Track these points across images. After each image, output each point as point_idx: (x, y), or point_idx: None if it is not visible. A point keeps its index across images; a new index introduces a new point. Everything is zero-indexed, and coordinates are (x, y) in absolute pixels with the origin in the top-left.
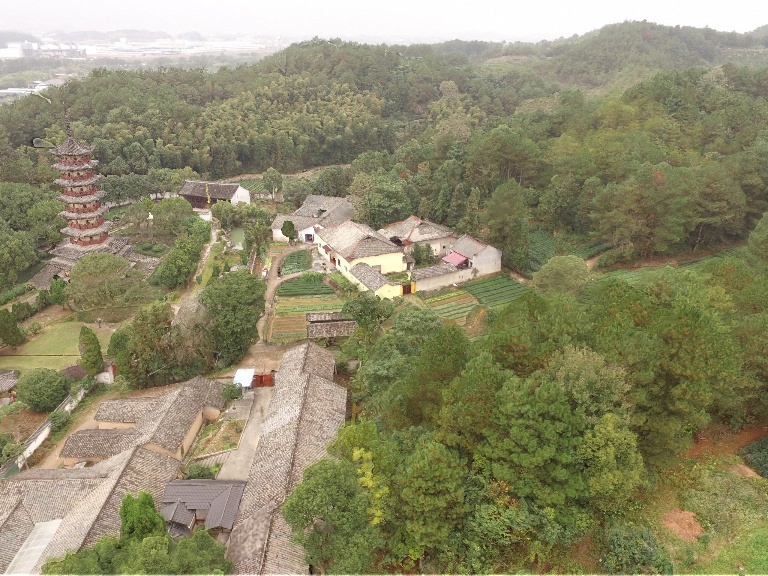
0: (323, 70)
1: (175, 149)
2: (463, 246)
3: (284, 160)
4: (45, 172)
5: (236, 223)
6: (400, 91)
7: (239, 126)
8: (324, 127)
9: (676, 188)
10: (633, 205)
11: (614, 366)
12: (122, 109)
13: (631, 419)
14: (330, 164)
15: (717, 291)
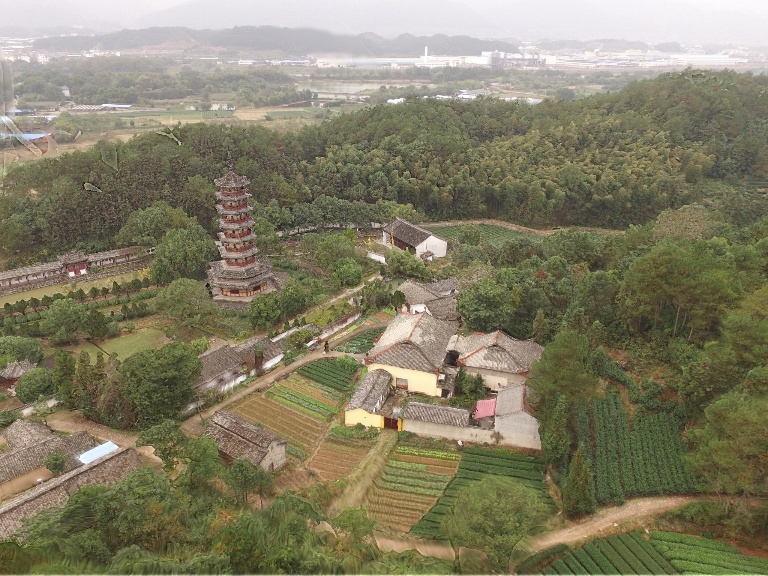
0: (653, 111)
1: (417, 183)
2: (508, 396)
3: (533, 212)
4: (284, 189)
5: (402, 274)
6: (747, 148)
7: (498, 168)
8: (596, 182)
9: None
10: (750, 448)
11: None
12: (392, 137)
13: None
14: (595, 226)
15: None
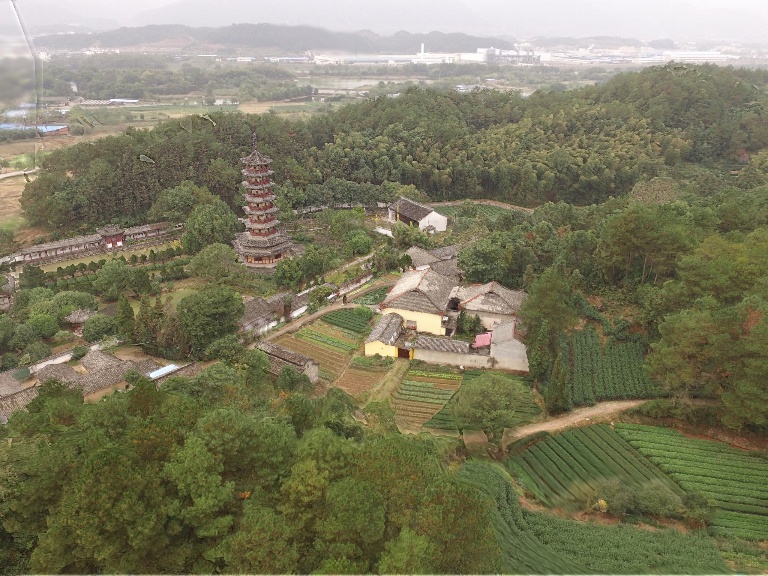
0: (637, 101)
1: (419, 166)
2: (502, 330)
3: (525, 192)
4: (298, 171)
5: (407, 245)
6: (722, 133)
7: (494, 152)
8: (583, 165)
9: (762, 346)
10: (689, 348)
11: (4, 465)
12: (395, 125)
13: (3, 521)
14: (582, 205)
15: (307, 468)
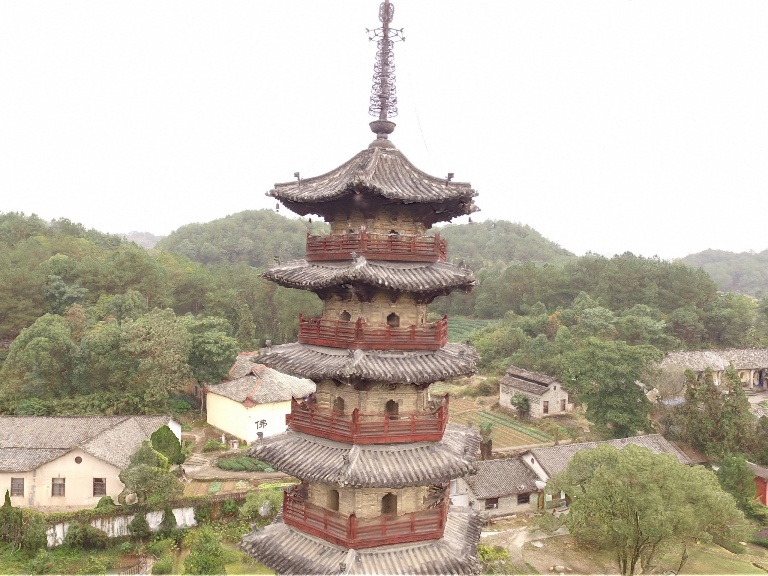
0: None
1: None
2: None
3: None
4: None
5: None
6: None
7: None
8: None
9: None
10: None
11: None
12: None
13: None
14: None
15: None
